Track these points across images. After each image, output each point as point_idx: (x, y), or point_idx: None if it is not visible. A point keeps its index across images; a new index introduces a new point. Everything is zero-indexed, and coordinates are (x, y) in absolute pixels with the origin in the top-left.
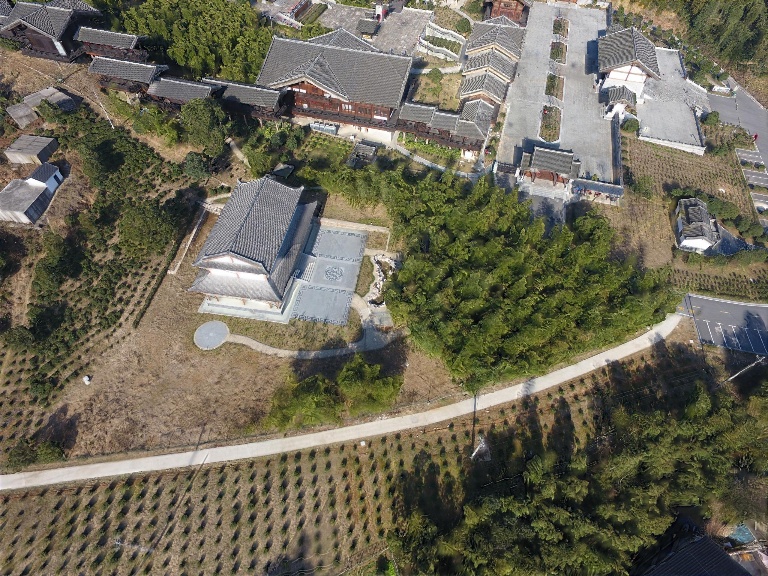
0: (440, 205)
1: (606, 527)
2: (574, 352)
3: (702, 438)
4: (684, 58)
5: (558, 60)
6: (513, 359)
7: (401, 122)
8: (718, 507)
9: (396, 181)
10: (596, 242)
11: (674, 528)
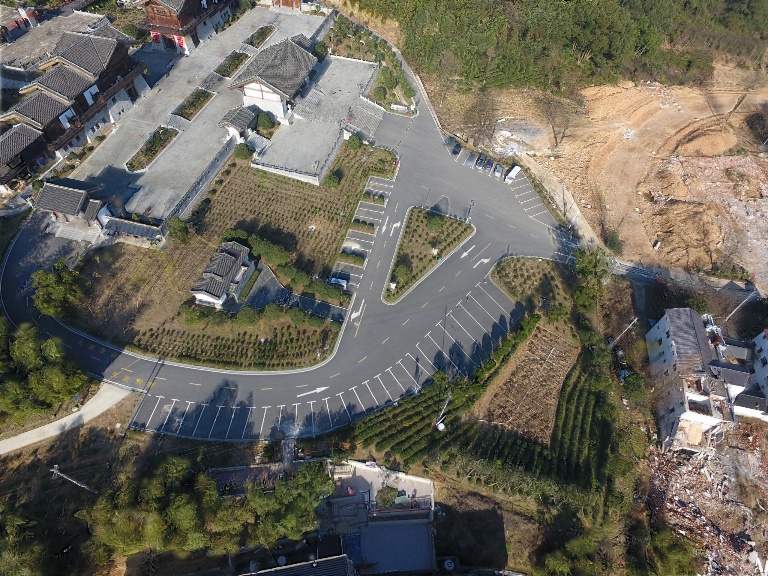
0: None
1: None
2: None
3: None
4: (381, 72)
5: (224, 73)
6: None
7: None
8: None
9: None
10: (34, 304)
11: None
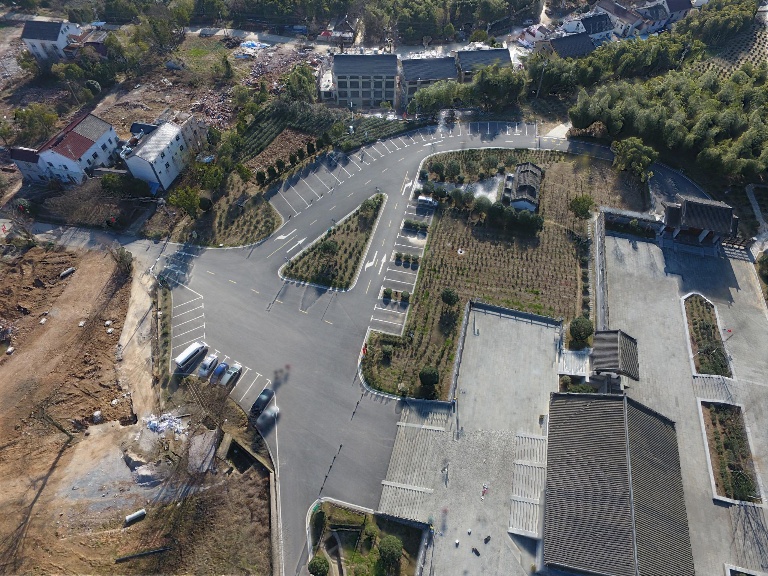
0: None
1: None
2: None
3: None
4: None
5: None
6: None
7: None
8: None
9: None
10: None
11: None
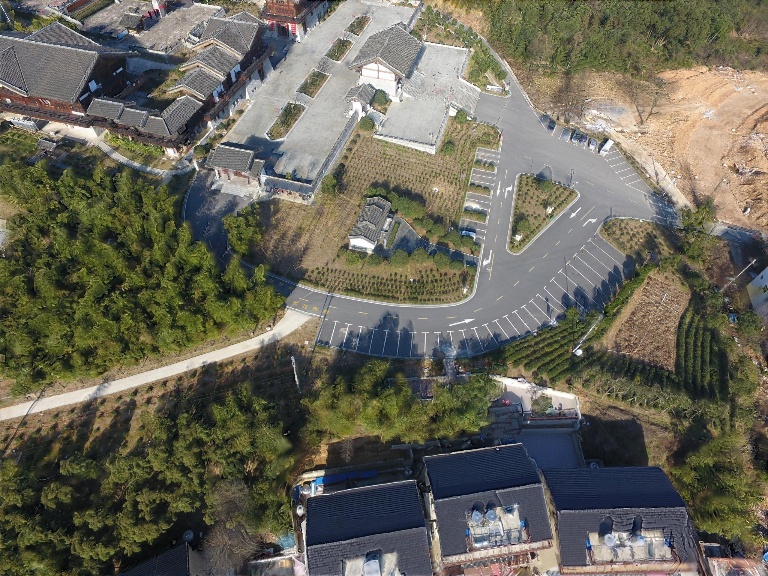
0: (75, 202)
1: (72, 534)
2: (131, 353)
3: (216, 442)
4: (472, 57)
5: (334, 57)
6: (51, 360)
7: (99, 118)
8: (223, 513)
9: (36, 177)
10: (230, 241)
11: (172, 534)
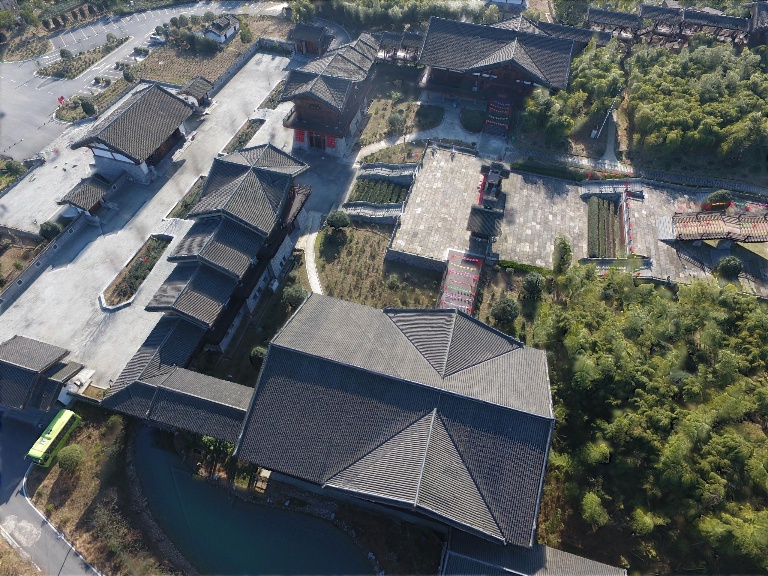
0: None
1: None
2: None
3: None
4: None
5: None
6: None
7: None
8: None
9: None
10: None
11: None
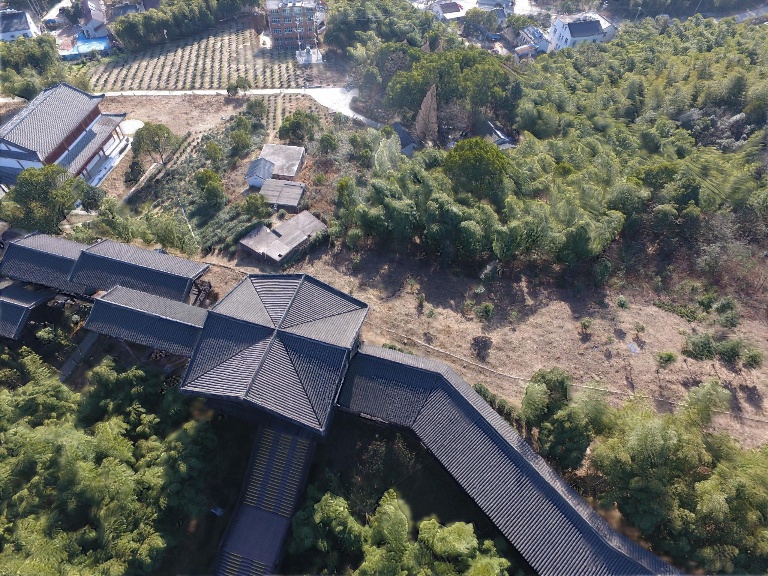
0: None
1: None
2: None
3: None
4: None
5: None
6: None
7: None
8: None
9: None
10: None
11: None
